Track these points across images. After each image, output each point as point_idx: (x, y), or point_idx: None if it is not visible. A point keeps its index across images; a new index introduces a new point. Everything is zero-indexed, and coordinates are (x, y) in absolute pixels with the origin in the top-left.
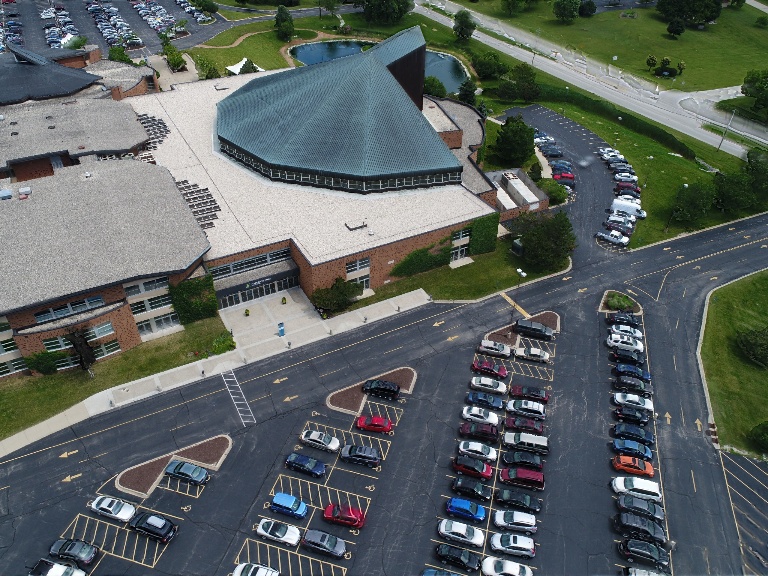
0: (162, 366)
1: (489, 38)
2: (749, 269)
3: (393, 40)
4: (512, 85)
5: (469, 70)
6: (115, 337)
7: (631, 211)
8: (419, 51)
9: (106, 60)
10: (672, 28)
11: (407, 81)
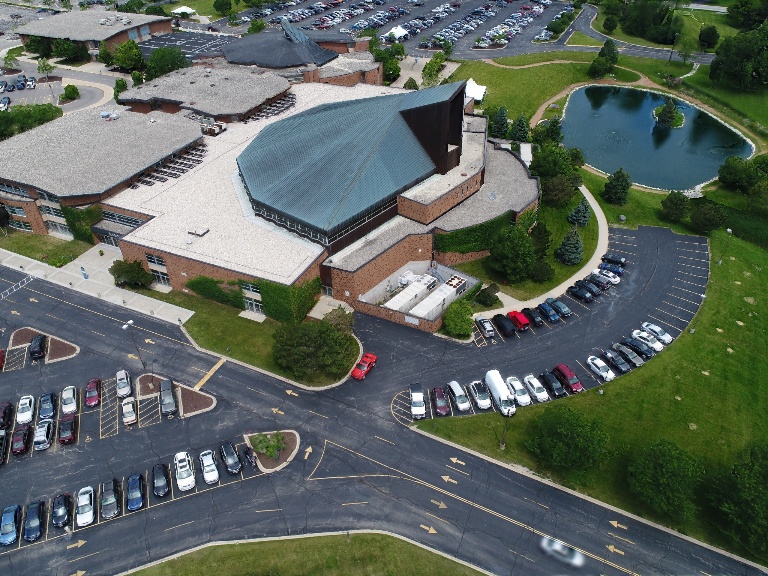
0: (26, 252)
1: None
2: (504, 569)
3: (431, 88)
4: (682, 199)
5: None
6: (28, 220)
7: (496, 395)
8: (440, 106)
9: (369, 51)
10: None
11: (425, 135)
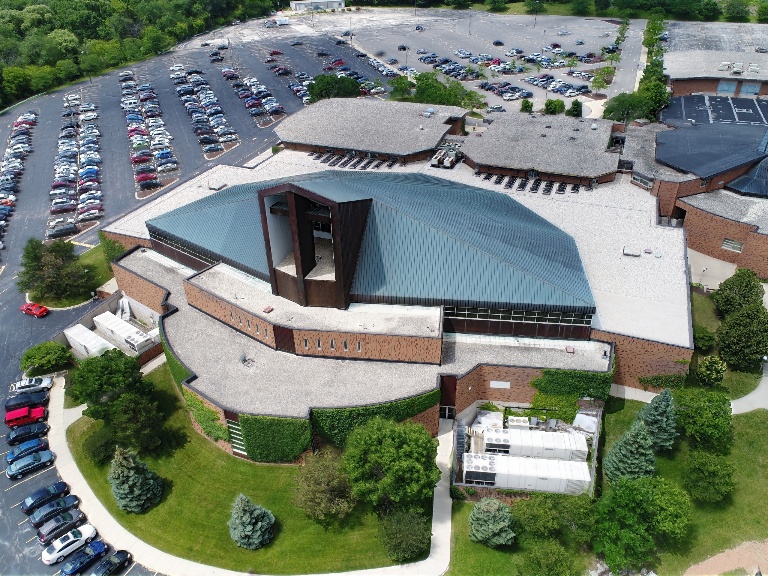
0: None
1: None
2: None
3: None
4: None
5: None
6: None
7: None
8: None
9: None
10: None
11: None
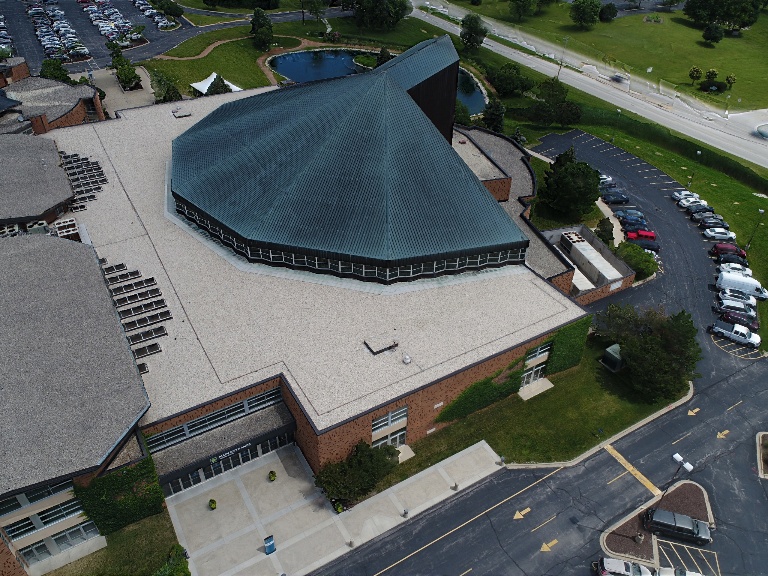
0: None
1: (500, 46)
2: None
3: (414, 55)
4: (547, 106)
5: (484, 85)
6: None
7: (748, 289)
8: (450, 70)
9: (35, 77)
10: (709, 35)
11: (433, 110)
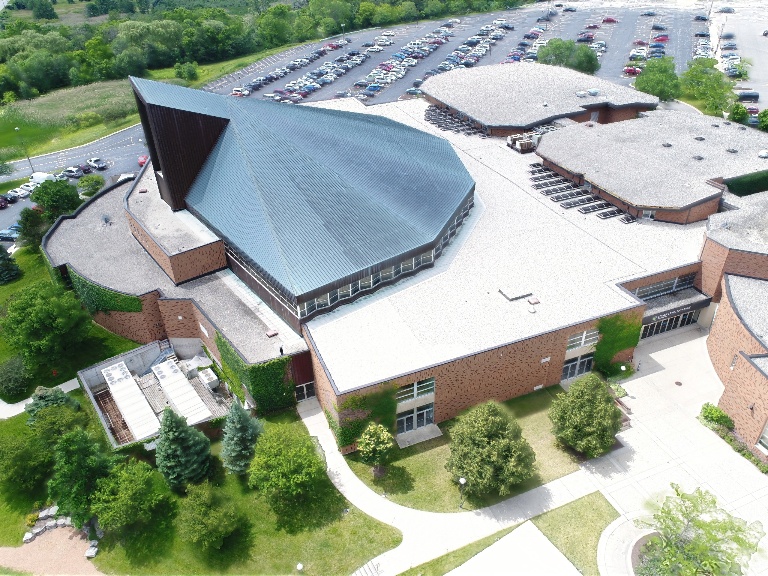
0: None
1: None
2: None
3: None
4: None
5: None
6: None
7: None
8: None
9: None
10: None
11: None
